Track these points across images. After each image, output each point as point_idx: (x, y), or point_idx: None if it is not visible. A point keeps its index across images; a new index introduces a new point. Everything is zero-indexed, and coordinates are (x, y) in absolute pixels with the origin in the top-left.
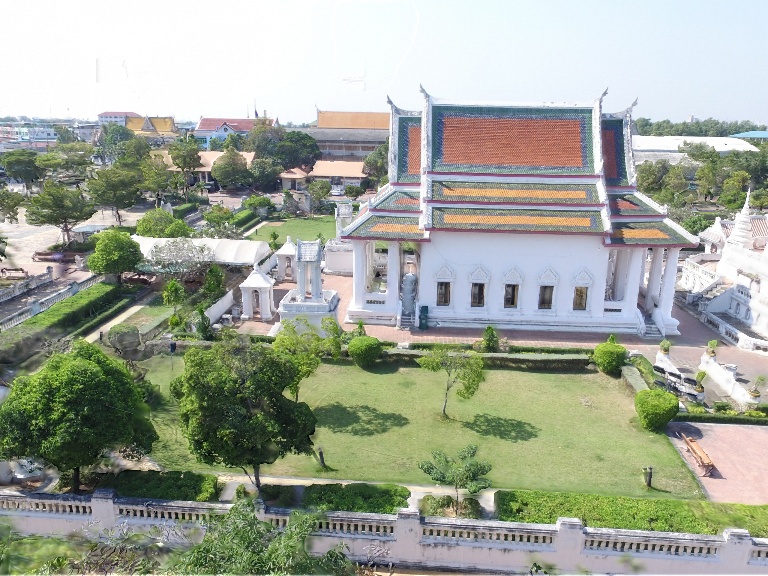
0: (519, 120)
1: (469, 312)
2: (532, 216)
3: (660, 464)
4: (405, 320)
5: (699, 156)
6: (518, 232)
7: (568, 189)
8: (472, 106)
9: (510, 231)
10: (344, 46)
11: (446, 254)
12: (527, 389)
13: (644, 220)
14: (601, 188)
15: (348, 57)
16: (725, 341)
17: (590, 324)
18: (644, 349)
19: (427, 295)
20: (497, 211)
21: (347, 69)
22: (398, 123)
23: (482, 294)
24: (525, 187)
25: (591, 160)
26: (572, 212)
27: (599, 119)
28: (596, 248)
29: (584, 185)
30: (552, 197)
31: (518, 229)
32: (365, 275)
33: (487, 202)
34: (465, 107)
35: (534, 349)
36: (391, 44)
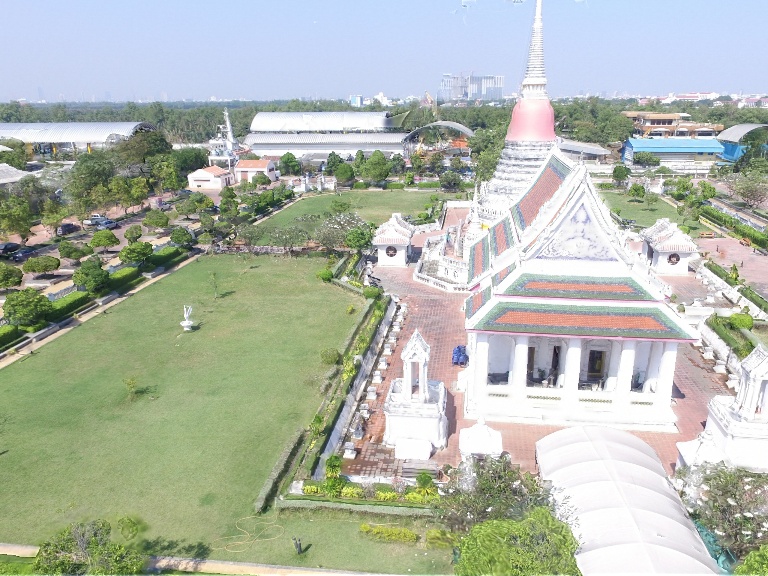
0: None
1: None
2: None
3: None
4: None
5: None
6: None
7: None
8: None
9: None
10: None
11: None
12: None
13: None
14: None
15: None
16: None
17: None
18: None
19: None
20: None
21: None
22: None
23: None
24: None
25: None
26: None
27: None
28: None
29: None
30: None
31: None
32: None
33: None
34: None
35: None
36: None
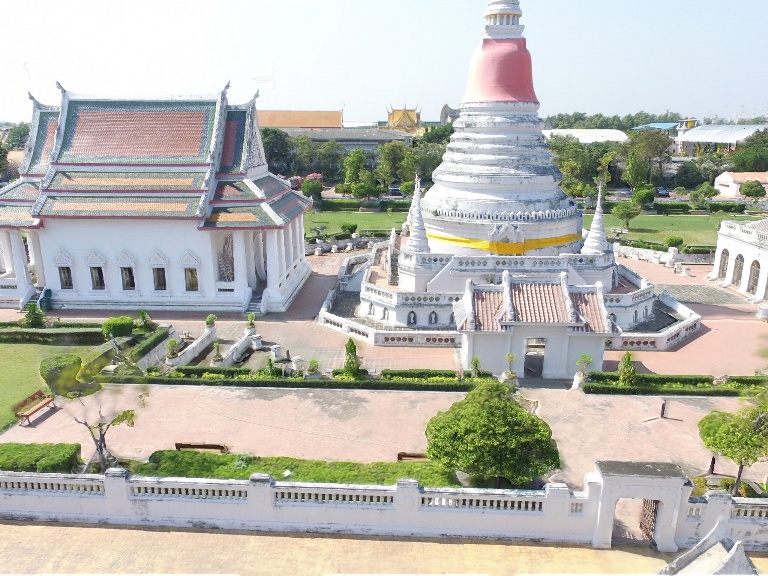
0: (148, 113)
1: (91, 294)
2: (136, 203)
3: (3, 417)
4: (31, 303)
5: (562, 148)
6: (117, 218)
7: (179, 177)
8: (106, 100)
9: (110, 217)
10: (251, 45)
11: (61, 240)
12: (14, 359)
13: (244, 205)
14: (207, 175)
15: (256, 56)
16: (318, 316)
17: (202, 303)
18: (226, 325)
19: (52, 279)
20: (106, 199)
21: (255, 68)
22: (39, 117)
23: (102, 277)
24: (141, 176)
25: (207, 149)
26: (175, 198)
27: (220, 111)
28: (197, 232)
29: (196, 173)
30: (160, 185)
31: (117, 215)
32: (12, 262)
33: (98, 190)
34: (99, 101)
35: (74, 324)
36: (300, 43)
